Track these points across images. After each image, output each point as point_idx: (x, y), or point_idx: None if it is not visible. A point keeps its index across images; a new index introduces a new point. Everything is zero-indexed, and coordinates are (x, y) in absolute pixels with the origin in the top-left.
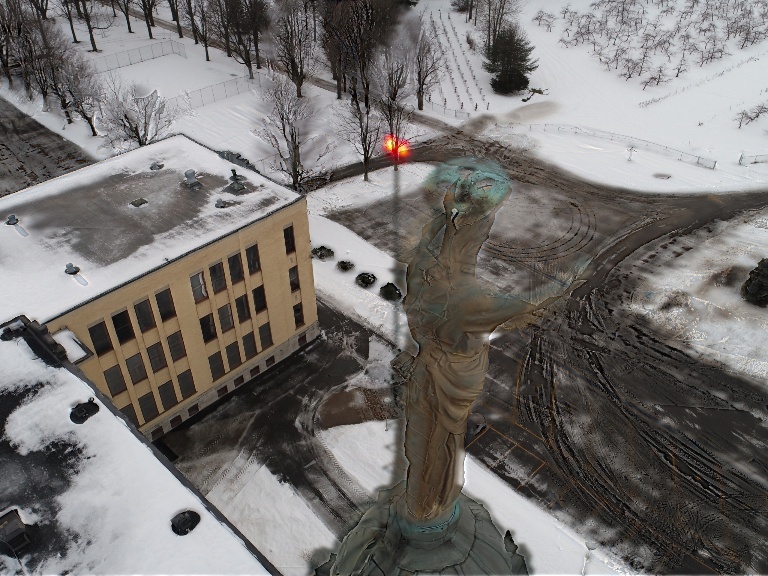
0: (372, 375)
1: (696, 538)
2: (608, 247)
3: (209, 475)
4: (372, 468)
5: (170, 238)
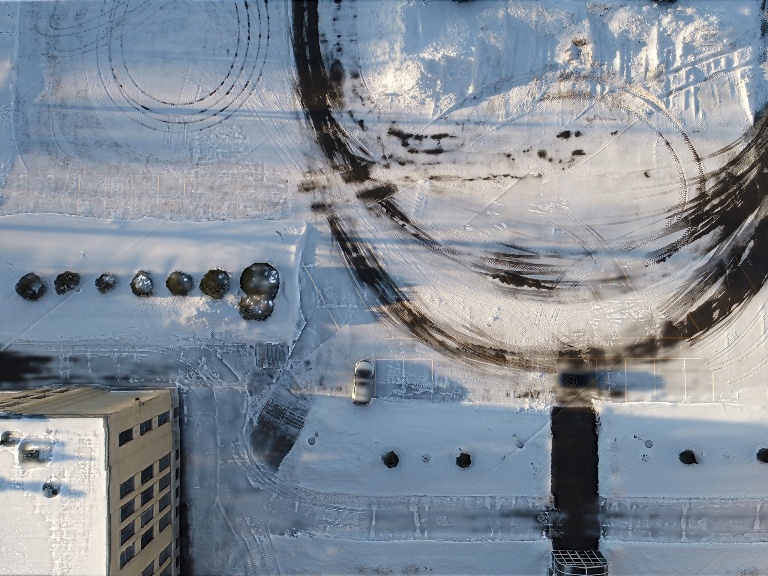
0: (257, 391)
1: (556, 341)
2: (290, 3)
3: (246, 573)
4: (338, 476)
5: (69, 571)
